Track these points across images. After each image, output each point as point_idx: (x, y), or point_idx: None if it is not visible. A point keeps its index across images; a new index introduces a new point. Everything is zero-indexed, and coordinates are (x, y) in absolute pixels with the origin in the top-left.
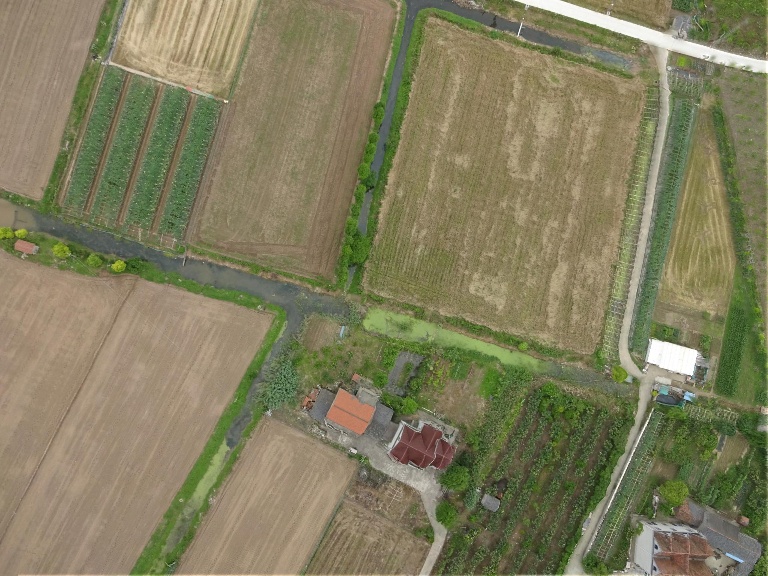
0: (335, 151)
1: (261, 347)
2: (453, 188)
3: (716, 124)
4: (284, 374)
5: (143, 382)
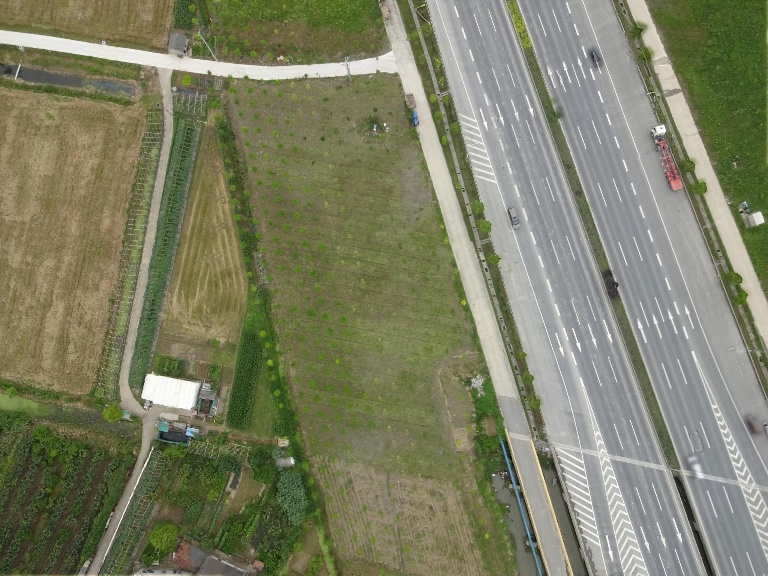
0: None
1: None
2: None
3: (221, 140)
4: None
5: None
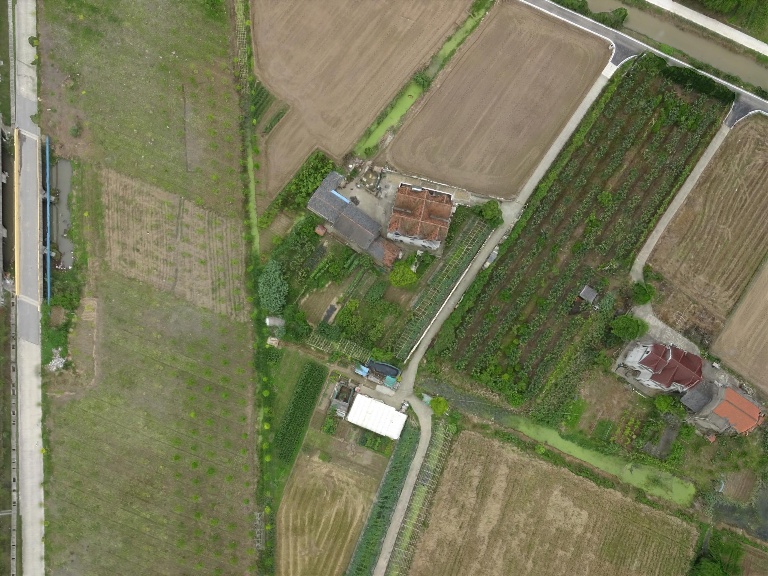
0: None
1: None
2: None
3: None
4: None
5: None
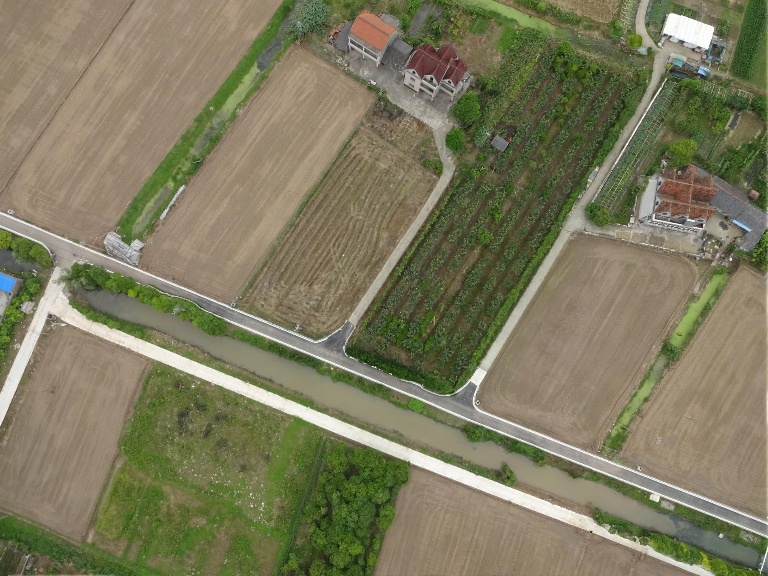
0: None
1: None
2: None
3: None
4: (315, 7)
5: (188, 4)
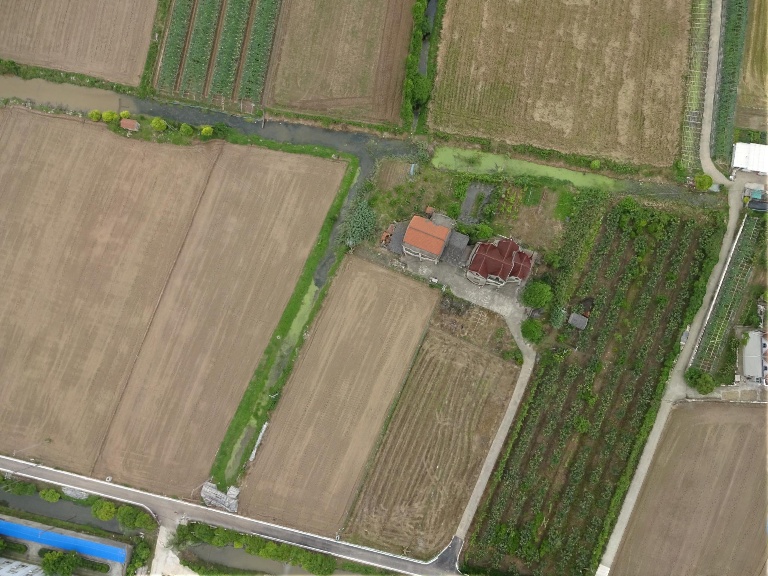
0: (390, 7)
1: (338, 192)
2: (507, 23)
3: None
4: (361, 213)
5: (236, 233)
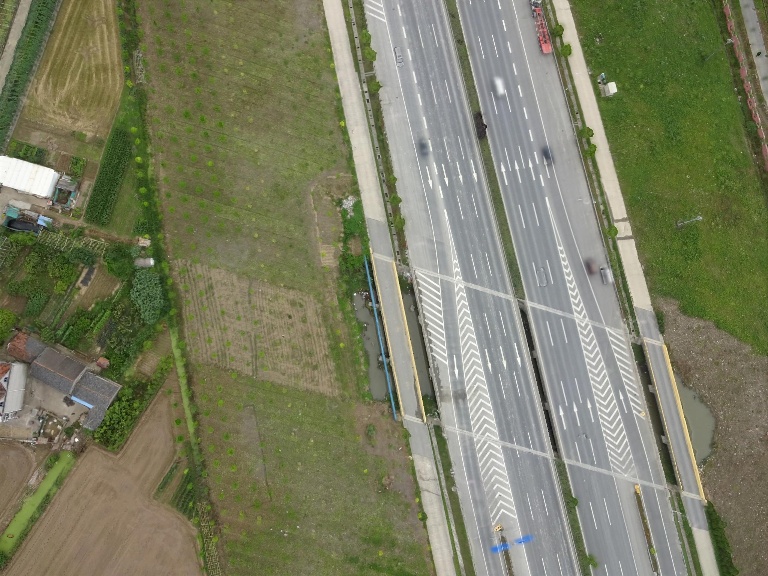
0: None
1: None
2: None
3: None
4: None
5: None
